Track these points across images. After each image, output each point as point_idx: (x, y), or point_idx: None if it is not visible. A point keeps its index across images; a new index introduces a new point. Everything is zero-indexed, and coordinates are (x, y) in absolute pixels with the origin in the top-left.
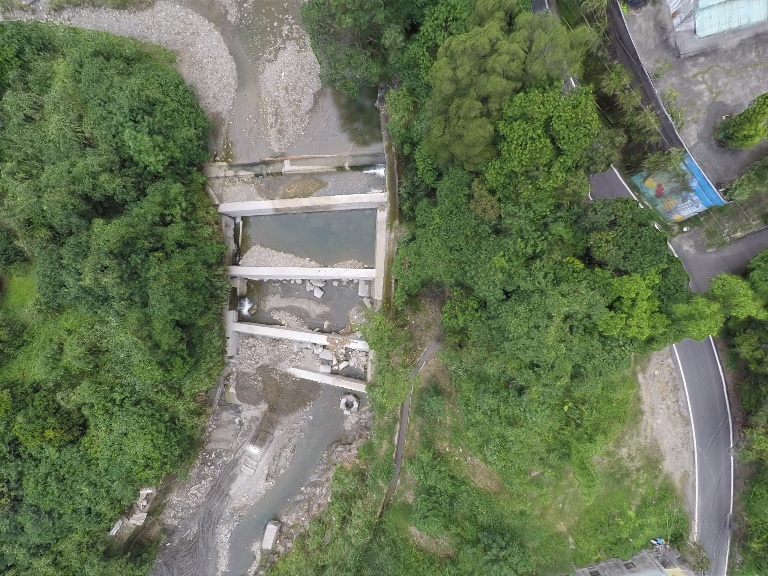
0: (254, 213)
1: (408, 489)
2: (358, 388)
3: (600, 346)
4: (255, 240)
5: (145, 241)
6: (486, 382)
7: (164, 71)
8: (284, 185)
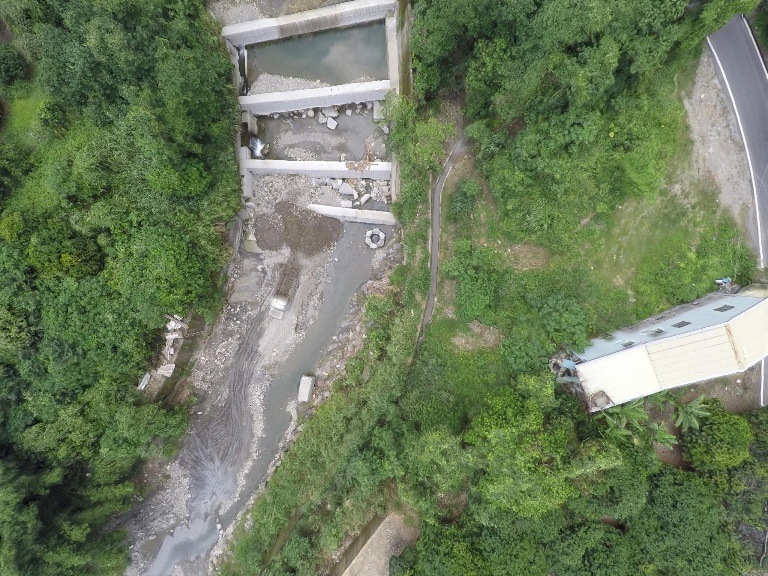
0: (258, 38)
1: (447, 304)
2: (383, 216)
3: (649, 2)
4: (262, 68)
5: (149, 19)
6: (522, 131)
7: None
8: (287, 1)
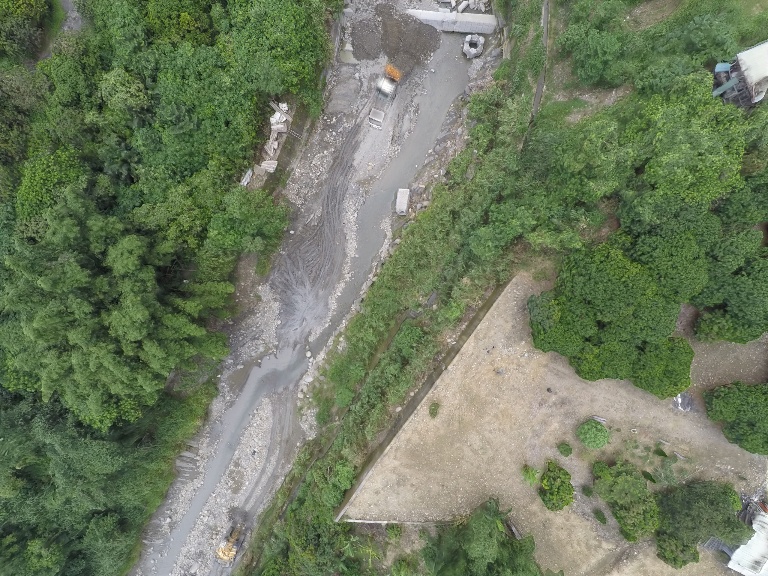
0: None
1: (557, 90)
2: (483, 19)
3: None
4: None
5: None
6: None
7: None
8: None
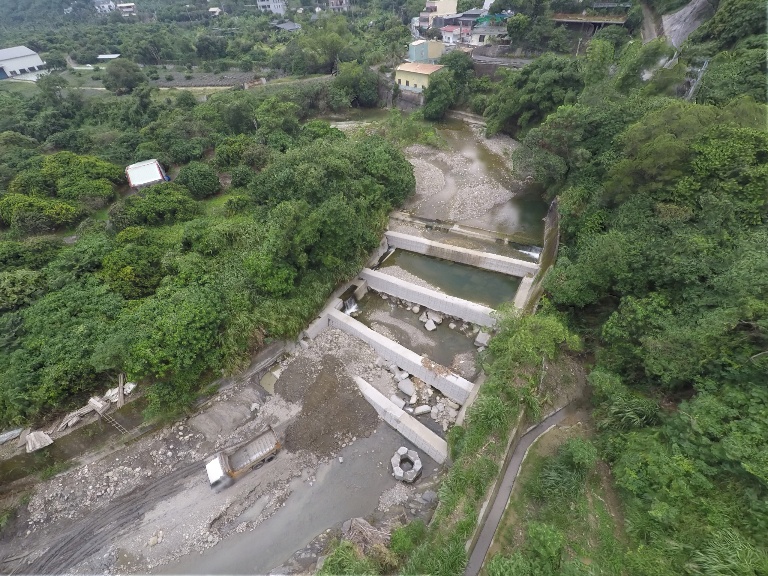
0: (409, 247)
1: None
2: (432, 439)
3: None
4: (398, 263)
5: None
6: (690, 399)
7: None
8: (446, 238)
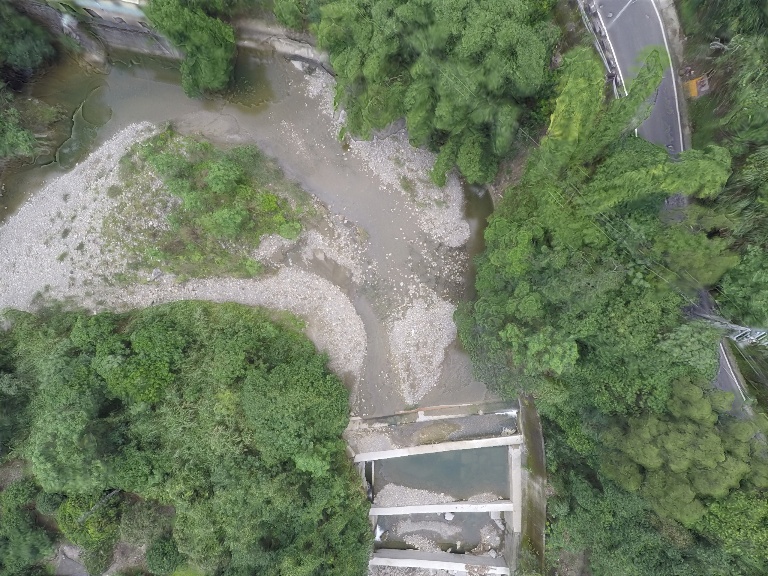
0: None
1: None
2: None
3: None
4: (388, 478)
5: (322, 558)
6: None
7: (297, 342)
8: (417, 431)
